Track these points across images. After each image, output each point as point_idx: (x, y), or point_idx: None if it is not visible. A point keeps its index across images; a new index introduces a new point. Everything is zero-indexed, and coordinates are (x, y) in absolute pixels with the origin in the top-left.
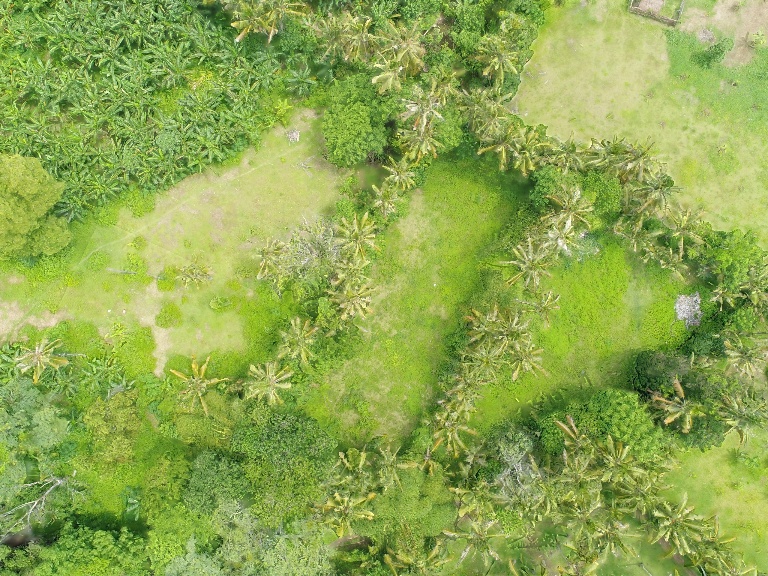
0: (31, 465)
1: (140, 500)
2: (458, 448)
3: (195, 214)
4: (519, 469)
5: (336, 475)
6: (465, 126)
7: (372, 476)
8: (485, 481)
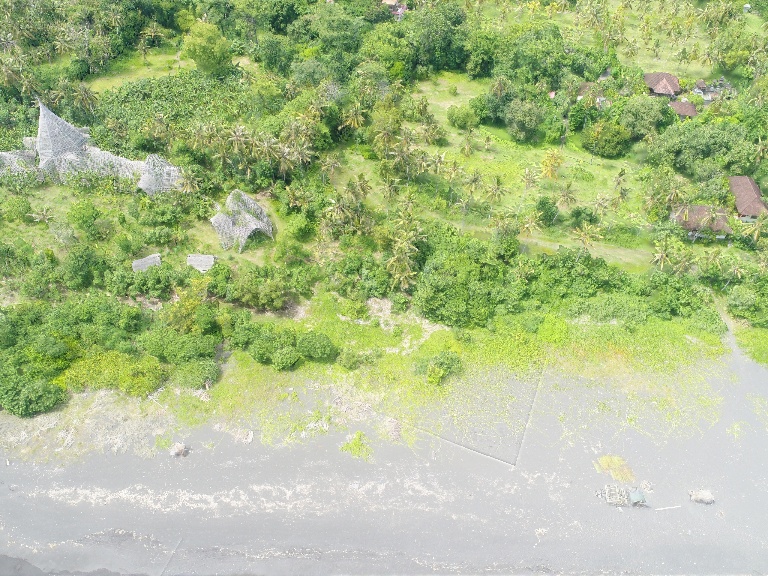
0: (234, 29)
1: (180, 7)
2: None
3: None
4: None
5: None
6: None
7: None
8: (48, 8)
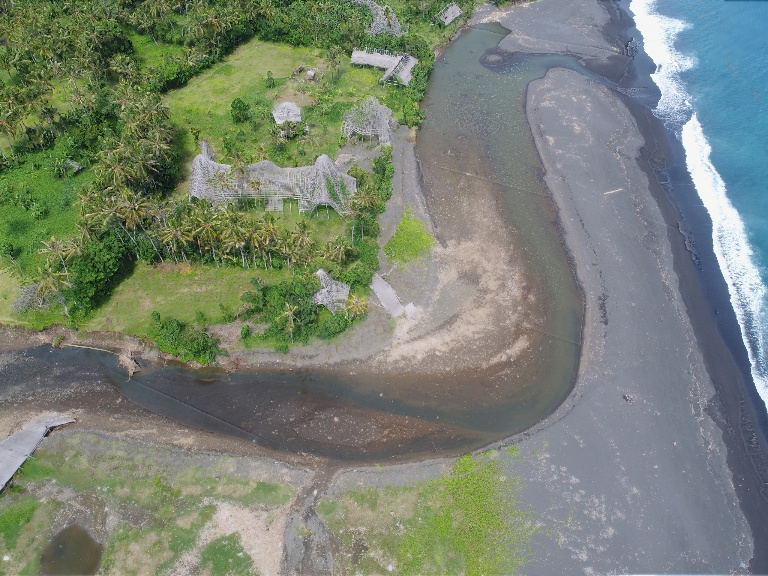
0: None
1: None
2: (119, 17)
3: None
4: (103, 2)
5: None
6: (250, 22)
7: None
8: None
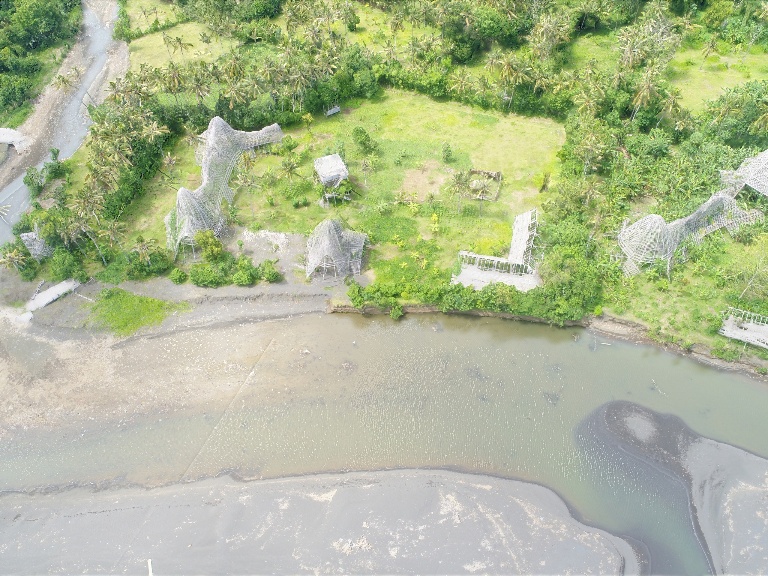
0: None
1: None
2: None
3: (723, 87)
4: None
5: (609, 6)
6: None
7: (592, 8)
8: (545, 3)
